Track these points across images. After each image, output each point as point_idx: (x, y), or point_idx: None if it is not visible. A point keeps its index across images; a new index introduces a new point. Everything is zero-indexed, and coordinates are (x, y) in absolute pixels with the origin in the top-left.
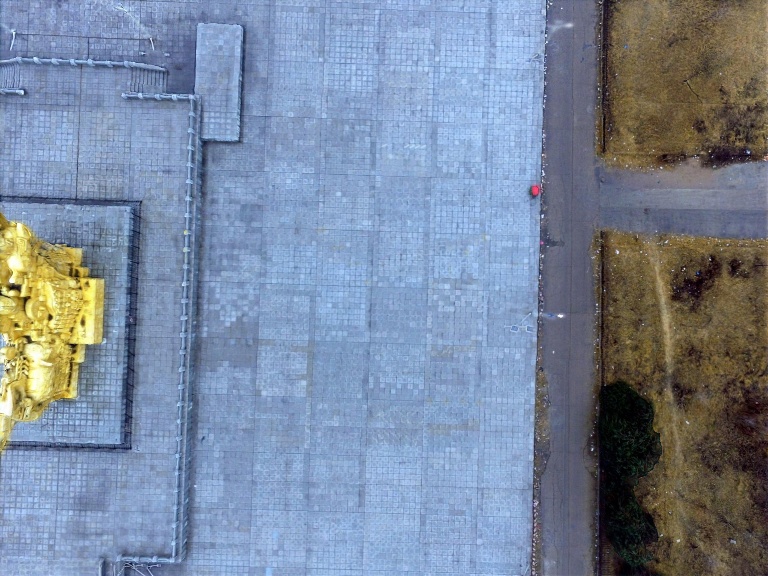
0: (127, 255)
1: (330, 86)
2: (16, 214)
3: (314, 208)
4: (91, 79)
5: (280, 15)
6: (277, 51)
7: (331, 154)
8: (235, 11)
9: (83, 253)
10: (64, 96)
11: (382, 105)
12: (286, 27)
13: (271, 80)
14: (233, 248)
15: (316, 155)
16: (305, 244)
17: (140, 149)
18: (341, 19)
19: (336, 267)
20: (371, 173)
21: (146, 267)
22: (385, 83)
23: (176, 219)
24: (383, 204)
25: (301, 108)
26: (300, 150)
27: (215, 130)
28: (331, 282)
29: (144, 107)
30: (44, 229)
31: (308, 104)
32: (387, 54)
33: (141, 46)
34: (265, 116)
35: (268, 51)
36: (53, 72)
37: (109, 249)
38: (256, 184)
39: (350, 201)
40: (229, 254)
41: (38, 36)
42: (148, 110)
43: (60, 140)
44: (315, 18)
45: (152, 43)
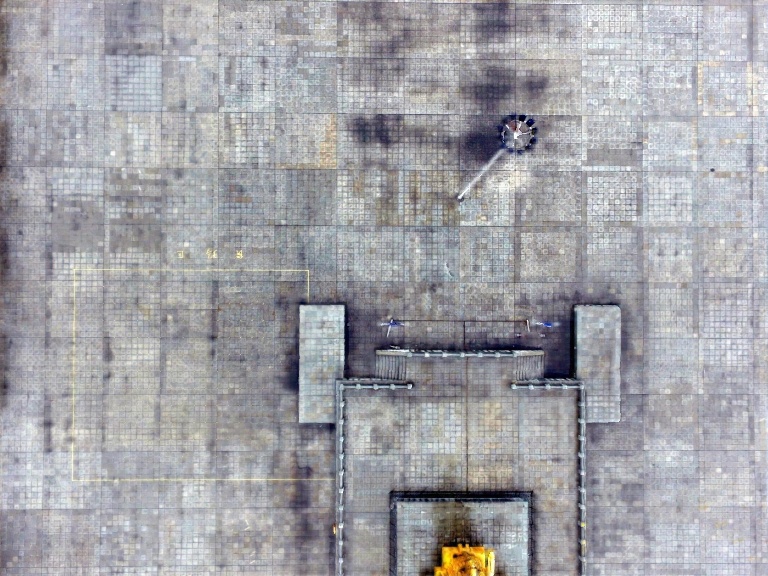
0: (527, 551)
1: (706, 361)
2: (415, 514)
3: (695, 485)
4: (477, 369)
5: (654, 292)
6: (652, 328)
7: (709, 430)
8: (608, 289)
9: (485, 551)
10: (451, 387)
11: (759, 379)
12: (660, 304)
13: (647, 357)
14: (616, 528)
15: (695, 431)
16: (688, 522)
17: (528, 438)
18: (714, 294)
19: (719, 544)
20: (750, 448)
21: (539, 557)
22: (760, 356)
23: (567, 508)
24: (764, 479)
25: (678, 384)
26: (679, 427)
27: (599, 414)
28: (715, 559)
29: (531, 396)
30: (444, 528)
31: (684, 380)
32: (762, 327)
33: (516, 328)
34: (642, 394)
35: (643, 328)
36: (439, 364)
37: (509, 546)
38: (636, 463)
39: (731, 477)
40: (612, 535)
41: (415, 322)
42: (535, 398)
43: (449, 432)
44: (688, 293)
45: (528, 325)
